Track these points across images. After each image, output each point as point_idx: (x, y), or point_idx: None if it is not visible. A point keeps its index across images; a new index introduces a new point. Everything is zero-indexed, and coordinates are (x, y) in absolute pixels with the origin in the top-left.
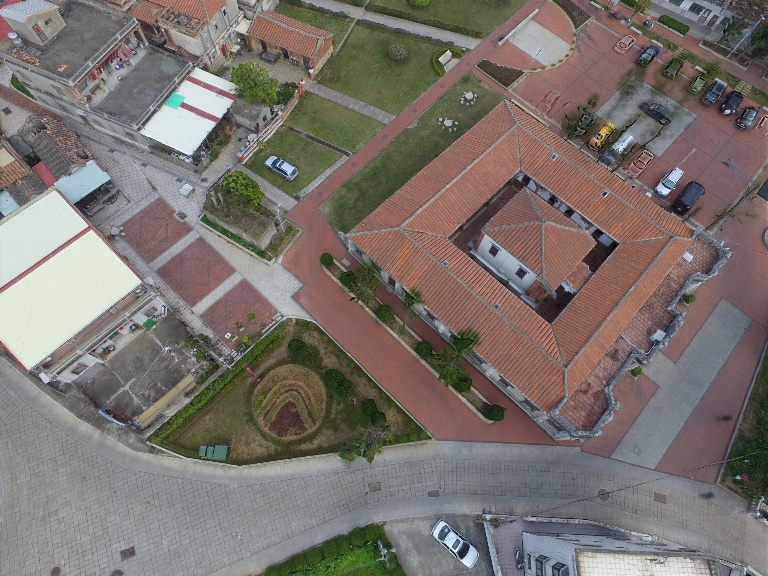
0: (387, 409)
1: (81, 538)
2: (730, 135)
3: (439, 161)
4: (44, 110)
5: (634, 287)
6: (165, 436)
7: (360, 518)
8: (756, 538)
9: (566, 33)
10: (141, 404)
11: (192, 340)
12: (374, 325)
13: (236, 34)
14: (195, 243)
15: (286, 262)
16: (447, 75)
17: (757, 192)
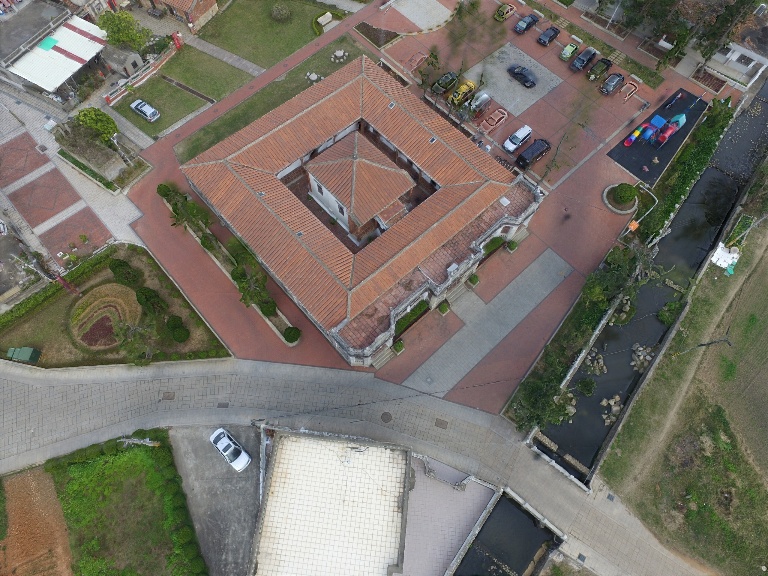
0: (196, 328)
1: None
2: (593, 100)
3: (284, 106)
4: None
5: (437, 224)
6: None
7: (148, 422)
8: (526, 465)
9: (450, 1)
10: None
11: (25, 256)
12: (201, 253)
13: None
14: (49, 173)
15: (131, 194)
16: (324, 35)
17: (607, 153)
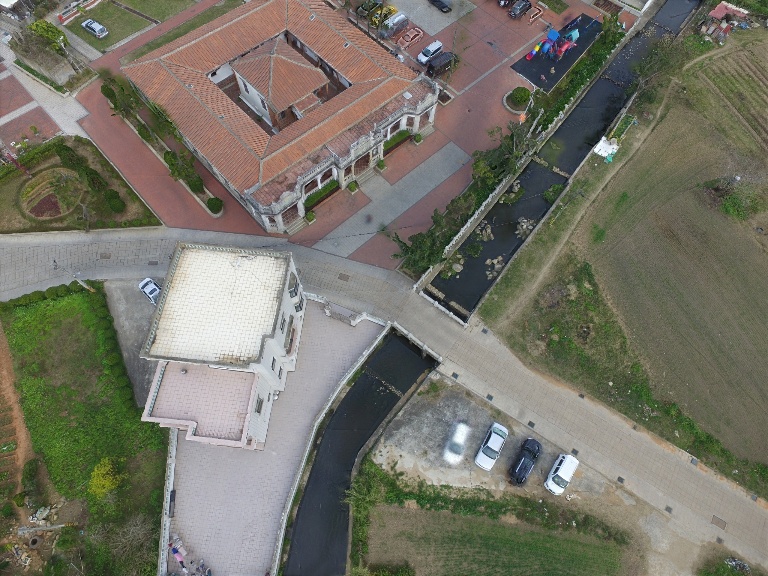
0: (132, 203)
1: None
2: (502, 22)
3: (217, 20)
4: None
5: (344, 109)
6: None
7: (86, 276)
8: (413, 307)
9: None
10: None
11: None
12: (140, 144)
13: None
14: (6, 79)
15: (79, 97)
16: None
17: (511, 65)
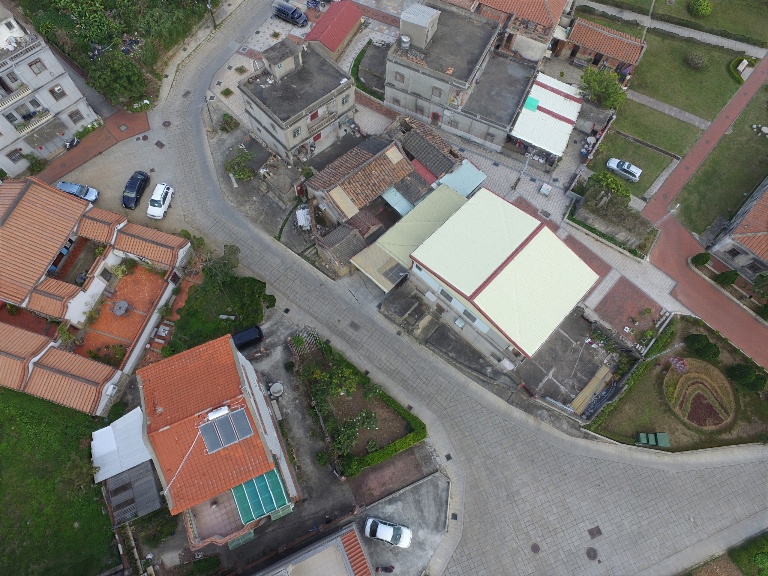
0: None
1: (548, 517)
2: None
3: None
4: (387, 110)
5: None
6: None
7: None
8: None
9: None
10: (569, 392)
11: (597, 333)
12: (754, 322)
13: (551, 40)
14: (566, 240)
15: (654, 260)
16: (746, 83)
17: None
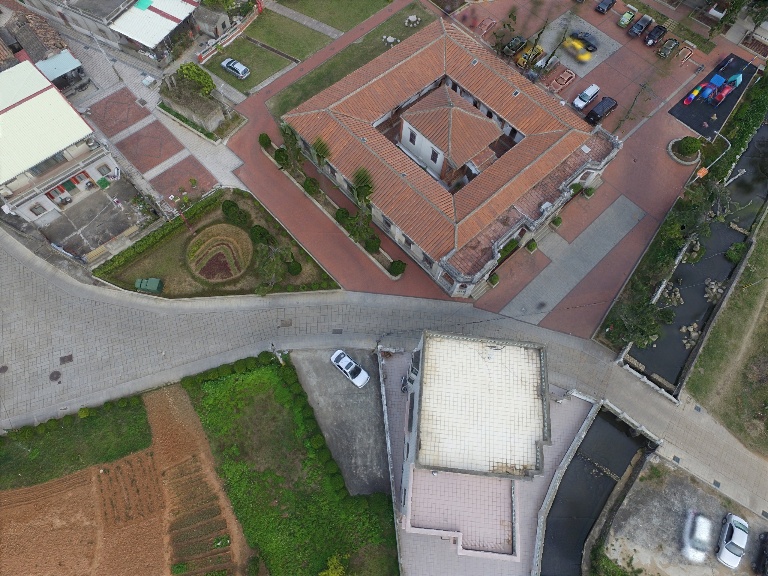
0: (305, 264)
1: (28, 345)
2: (651, 63)
3: (373, 63)
4: (31, 12)
5: (529, 166)
6: (108, 272)
7: None
8: (619, 382)
9: None
10: (90, 245)
11: (140, 198)
12: (302, 198)
13: None
14: (152, 124)
15: (230, 144)
16: (396, 2)
17: (668, 111)
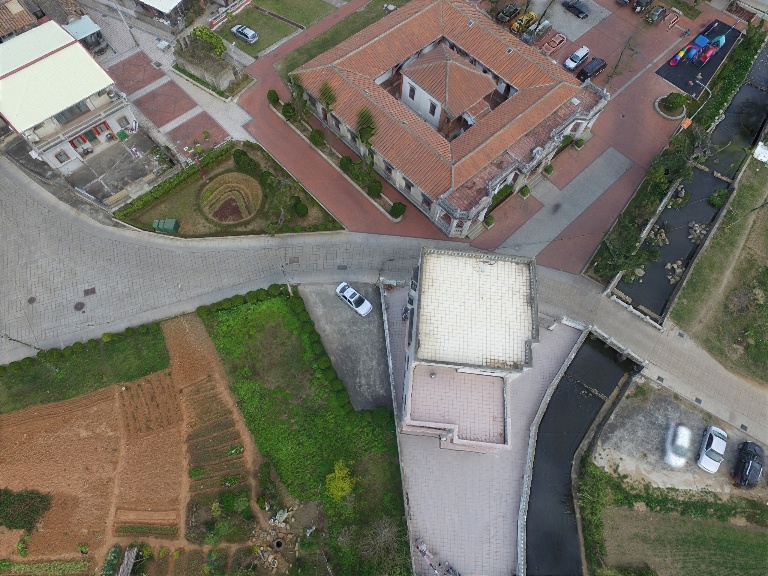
0: (311, 208)
1: (54, 279)
2: (639, 28)
3: (374, 26)
4: None
5: (522, 115)
6: (127, 214)
7: (279, 280)
8: (607, 311)
9: None
10: (110, 191)
11: (156, 149)
12: (308, 149)
13: None
14: (166, 84)
15: (240, 102)
16: None
17: (655, 71)
